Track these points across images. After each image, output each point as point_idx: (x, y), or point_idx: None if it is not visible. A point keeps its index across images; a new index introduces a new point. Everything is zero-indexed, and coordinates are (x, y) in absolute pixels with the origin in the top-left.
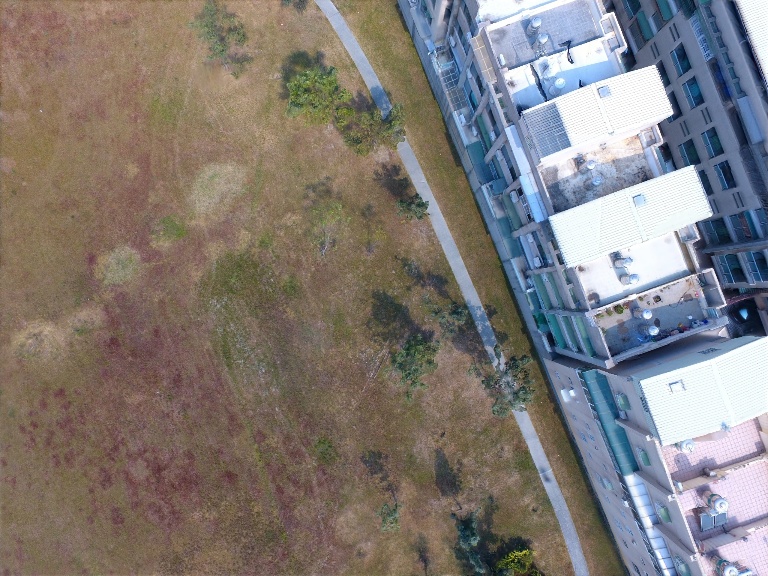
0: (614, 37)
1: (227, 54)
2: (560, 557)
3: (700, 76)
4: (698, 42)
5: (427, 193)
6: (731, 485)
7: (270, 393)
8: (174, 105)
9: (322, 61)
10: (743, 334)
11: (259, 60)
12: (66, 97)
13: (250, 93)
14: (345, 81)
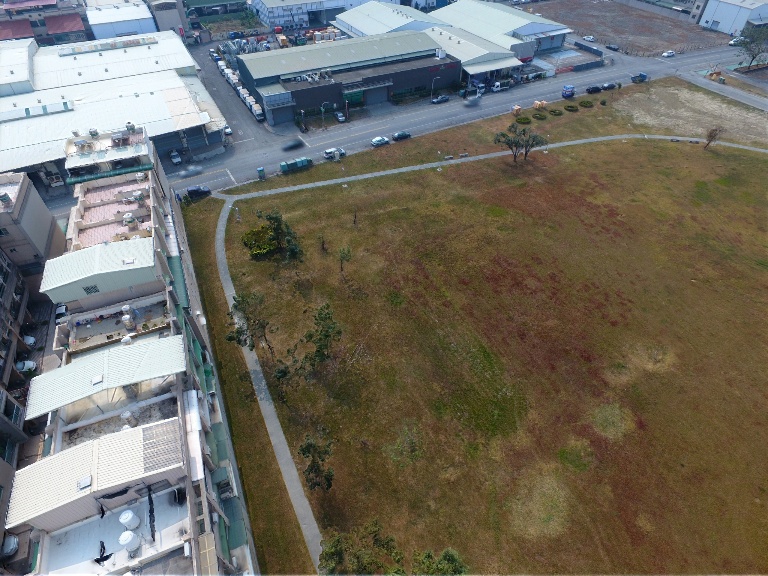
0: None
1: None
2: (232, 254)
3: None
4: None
5: (301, 511)
6: (114, 232)
7: (444, 331)
8: None
9: None
10: (27, 381)
11: None
12: None
13: None
14: None
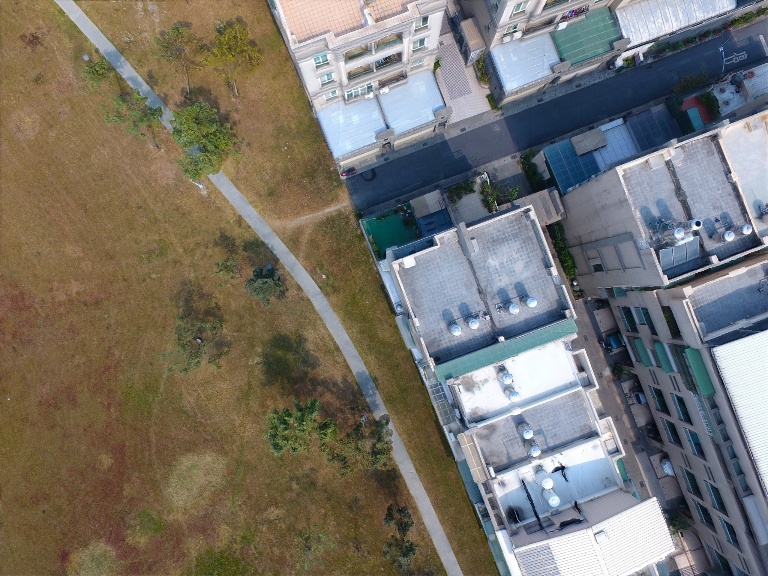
0: (611, 438)
1: (204, 337)
2: None
3: (702, 439)
4: (700, 414)
5: (416, 484)
6: None
7: None
8: (149, 392)
9: (304, 345)
10: None
11: (238, 344)
12: (35, 384)
13: (229, 379)
14: (329, 366)
